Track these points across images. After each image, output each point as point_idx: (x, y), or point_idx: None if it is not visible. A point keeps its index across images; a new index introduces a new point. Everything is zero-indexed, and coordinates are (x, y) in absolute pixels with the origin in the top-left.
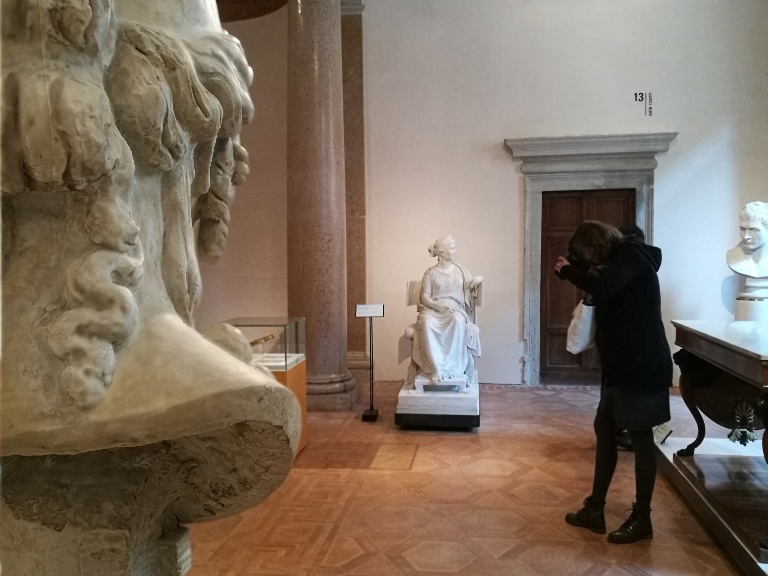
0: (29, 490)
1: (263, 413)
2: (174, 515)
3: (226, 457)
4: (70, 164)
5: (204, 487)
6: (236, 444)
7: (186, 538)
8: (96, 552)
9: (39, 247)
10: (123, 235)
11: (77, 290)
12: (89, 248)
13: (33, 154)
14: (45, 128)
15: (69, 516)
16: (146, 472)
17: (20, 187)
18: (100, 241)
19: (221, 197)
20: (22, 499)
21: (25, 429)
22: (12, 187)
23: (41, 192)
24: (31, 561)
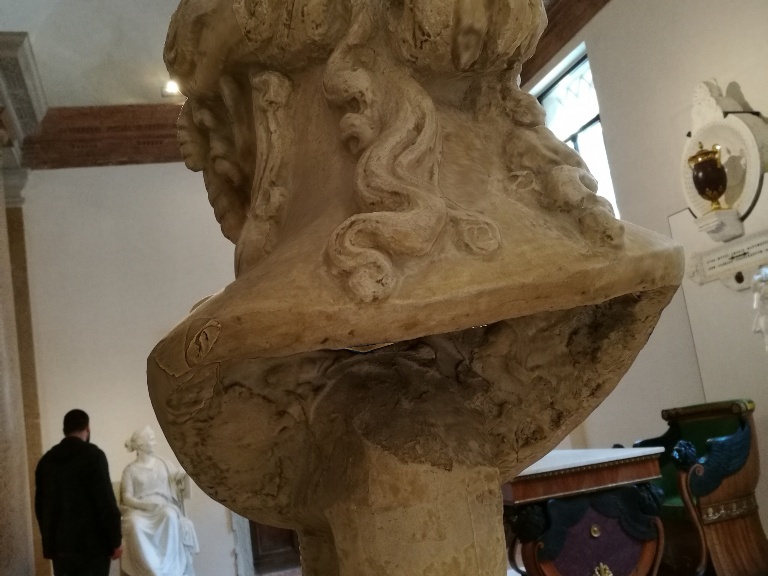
0: (401, 433)
1: None
2: None
3: (551, 387)
4: None
5: (510, 436)
6: (571, 365)
7: None
8: (479, 494)
9: (458, 133)
10: None
11: (551, 151)
12: (517, 129)
13: (513, 15)
14: None
15: (451, 455)
16: (482, 413)
17: (476, 57)
18: (529, 120)
19: None
20: (399, 443)
21: (575, 269)
22: (471, 56)
23: (452, 80)
24: (422, 514)
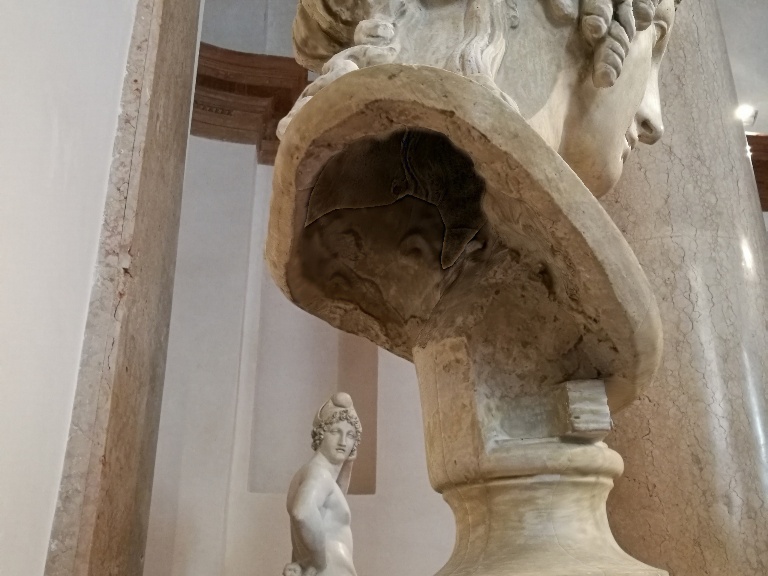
0: None
1: (402, 91)
2: (594, 368)
3: (535, 231)
4: (327, 1)
5: (563, 296)
6: None
7: (595, 387)
8: (446, 365)
9: None
10: (364, 31)
11: None
12: None
13: (306, 7)
14: None
15: (433, 334)
16: (499, 285)
17: (325, 44)
18: None
19: (591, 12)
20: None
21: None
22: (323, 47)
23: None
24: None
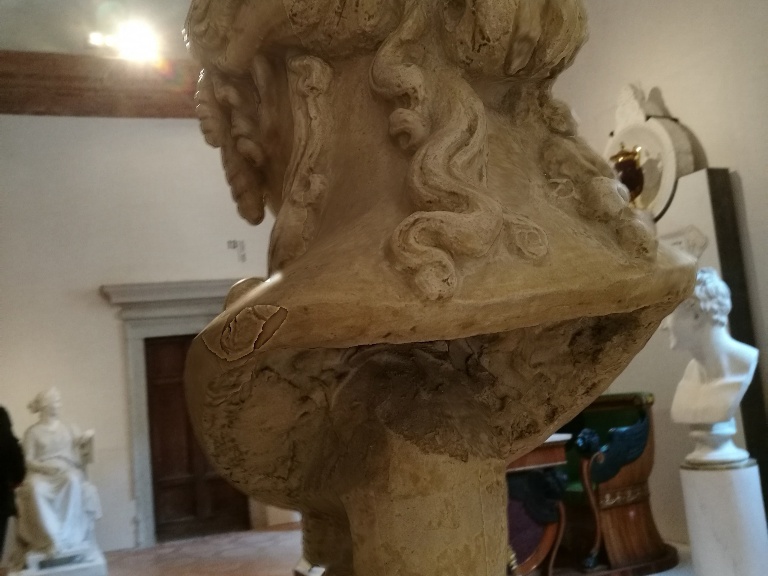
0: (421, 424)
1: None
2: None
3: (550, 384)
4: None
5: (507, 429)
6: (571, 364)
7: None
8: (489, 485)
9: (499, 136)
10: None
11: (589, 162)
12: (553, 136)
13: (565, 27)
14: (574, 5)
15: (466, 446)
16: (488, 406)
17: None
18: (565, 129)
19: None
20: (420, 433)
21: (616, 278)
22: (521, 62)
23: (495, 83)
24: (439, 503)
